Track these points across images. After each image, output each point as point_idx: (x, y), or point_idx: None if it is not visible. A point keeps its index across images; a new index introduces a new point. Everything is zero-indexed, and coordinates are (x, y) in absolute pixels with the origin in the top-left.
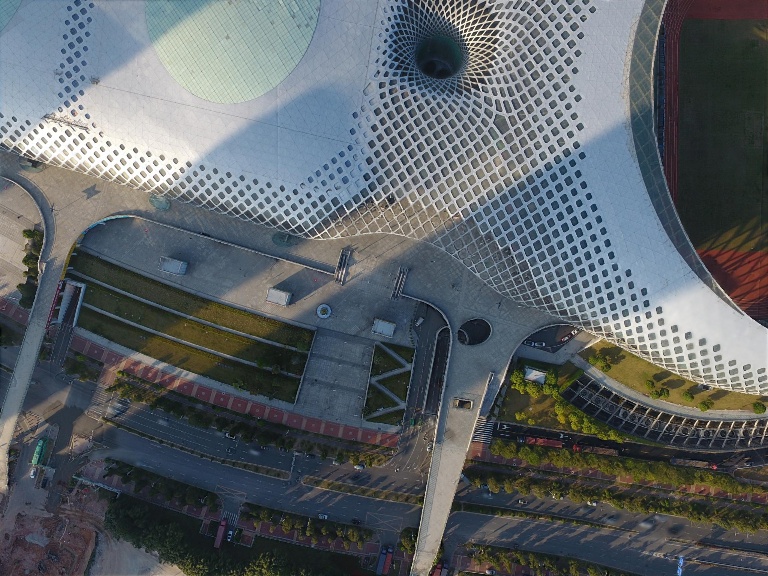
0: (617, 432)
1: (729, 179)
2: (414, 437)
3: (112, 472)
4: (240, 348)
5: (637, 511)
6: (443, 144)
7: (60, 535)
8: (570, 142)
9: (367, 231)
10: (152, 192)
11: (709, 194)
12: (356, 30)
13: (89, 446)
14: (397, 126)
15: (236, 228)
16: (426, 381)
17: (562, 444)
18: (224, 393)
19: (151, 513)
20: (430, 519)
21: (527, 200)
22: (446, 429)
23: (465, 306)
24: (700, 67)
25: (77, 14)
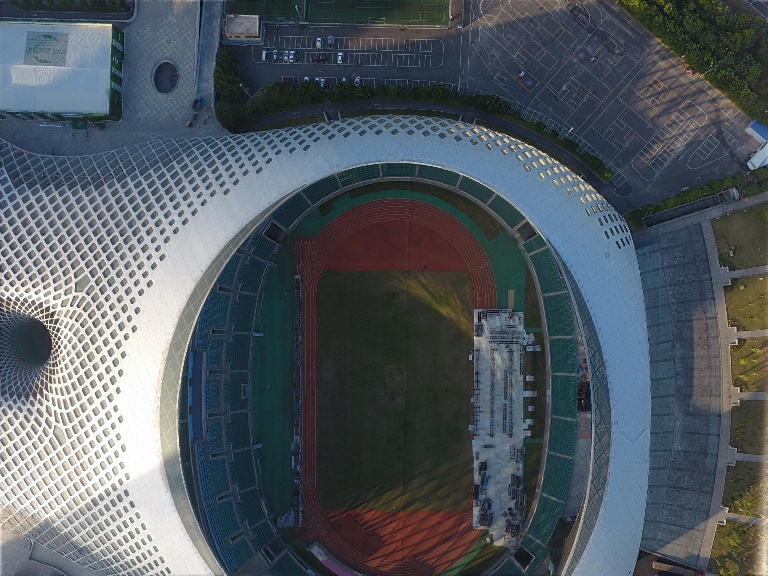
0: None
1: (370, 437)
2: None
3: None
4: None
5: None
6: (11, 450)
7: None
8: (117, 461)
9: None
10: None
11: (349, 452)
12: None
13: None
14: None
15: None
16: None
17: None
18: None
19: None
20: None
21: (90, 509)
22: None
23: (93, 571)
24: (339, 321)
25: None
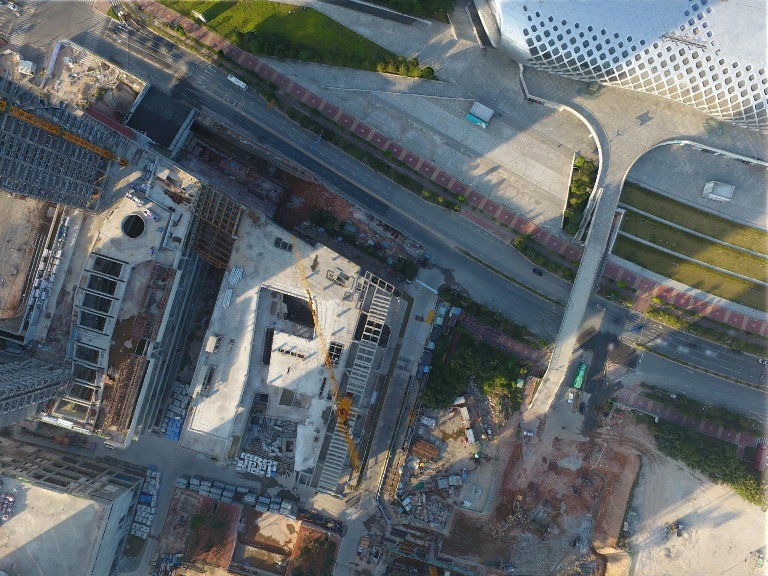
0: None
1: None
2: None
3: None
4: None
5: None
6: None
7: (596, 459)
8: None
9: None
10: (733, 114)
11: None
12: None
13: (622, 372)
14: None
15: None
16: None
17: None
18: (756, 319)
19: None
20: None
21: None
22: None
23: None
24: None
25: None
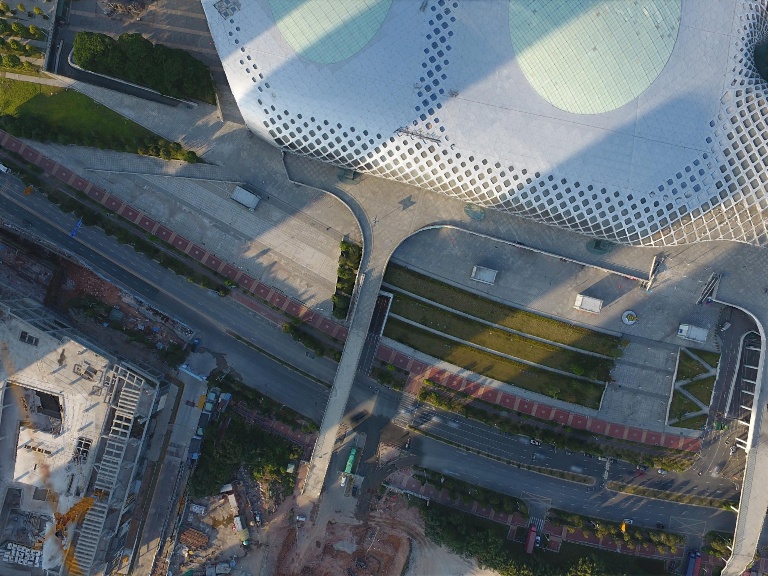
0: None
1: None
2: (716, 441)
3: (425, 480)
4: (544, 355)
5: None
6: None
7: (370, 542)
8: None
9: (707, 238)
10: (483, 202)
11: None
12: (714, 39)
13: (396, 454)
14: (752, 134)
15: (550, 236)
16: (729, 386)
17: None
18: (528, 400)
19: None
20: (746, 523)
21: None
22: (760, 433)
23: None
24: None
25: (438, 28)
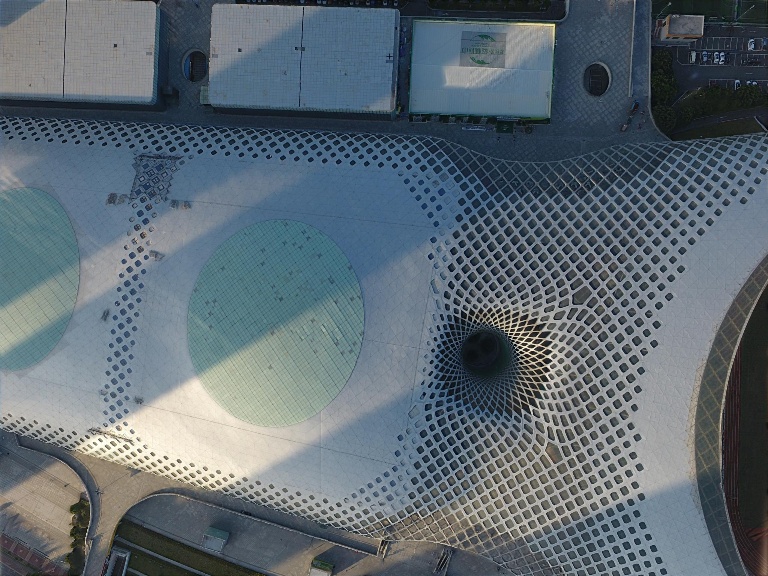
0: None
1: None
2: None
3: None
4: None
5: None
6: (492, 467)
7: None
8: (628, 481)
9: (412, 538)
10: None
11: None
12: (401, 352)
13: None
14: (443, 447)
15: None
16: None
17: None
18: None
19: None
20: None
21: (581, 529)
22: None
23: None
24: (765, 333)
25: (121, 337)
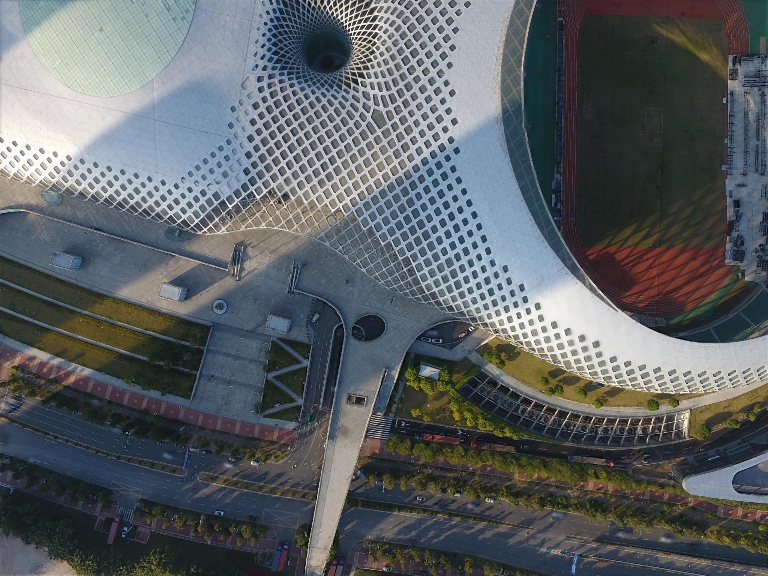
0: (513, 429)
1: (628, 176)
2: (311, 433)
3: (4, 468)
4: (136, 343)
5: (533, 508)
6: (322, 139)
7: None
8: (445, 137)
9: (251, 226)
10: (38, 186)
11: (608, 191)
12: (234, 23)
13: None
14: (276, 120)
15: (128, 223)
16: (323, 377)
17: (460, 441)
18: (120, 389)
19: (44, 509)
20: (323, 515)
21: (405, 195)
22: (339, 425)
23: (359, 302)
24: (599, 63)
25: None
